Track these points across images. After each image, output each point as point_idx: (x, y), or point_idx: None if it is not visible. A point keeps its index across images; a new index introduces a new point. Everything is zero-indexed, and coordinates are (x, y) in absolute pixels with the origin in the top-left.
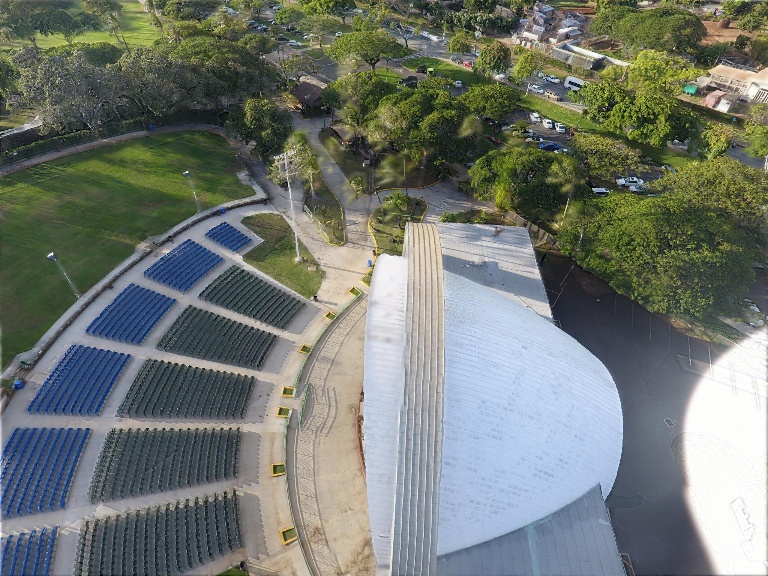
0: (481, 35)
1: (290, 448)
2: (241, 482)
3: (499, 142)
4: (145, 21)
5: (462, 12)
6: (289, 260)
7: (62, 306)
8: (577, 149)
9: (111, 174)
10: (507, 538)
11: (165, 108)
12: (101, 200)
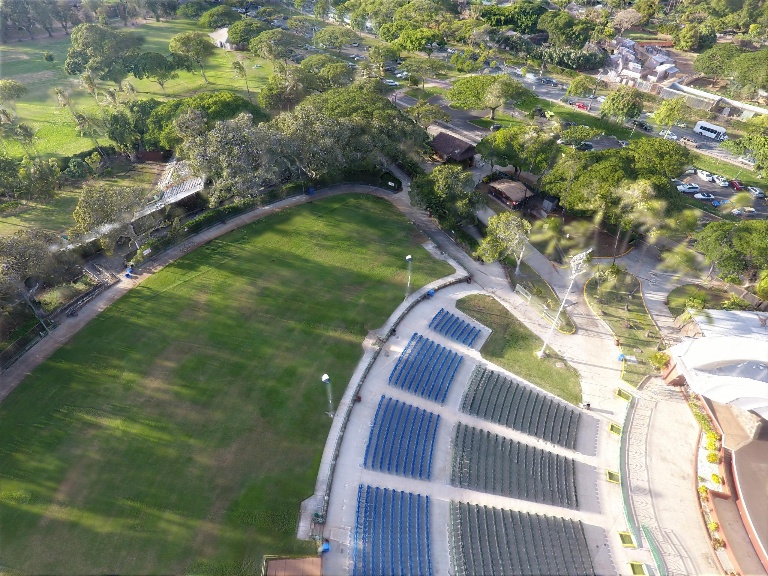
0: (579, 73)
1: None
2: None
3: None
4: (221, 57)
5: (553, 48)
6: (530, 355)
7: (320, 430)
8: None
9: (293, 251)
10: None
11: (326, 170)
12: (298, 285)
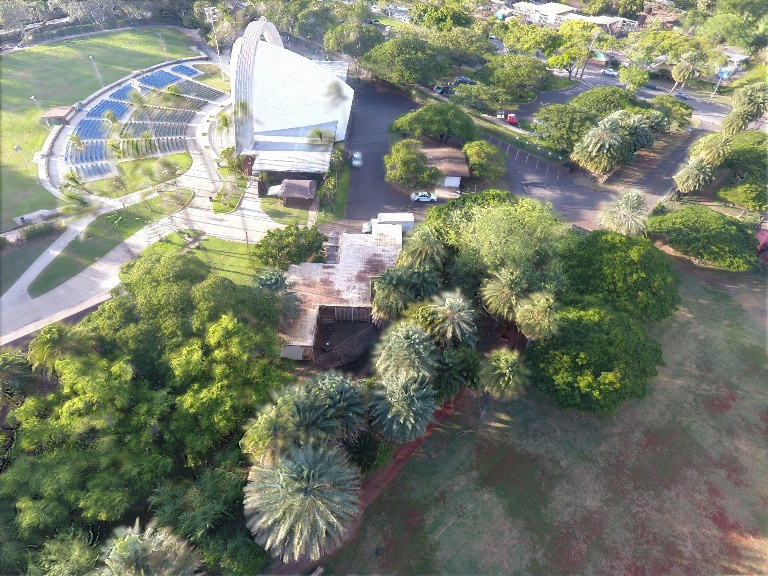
0: None
1: (211, 130)
2: (187, 137)
3: None
4: None
5: None
6: (218, 80)
7: (95, 89)
8: None
9: (113, 44)
10: (292, 129)
11: (145, 13)
12: (109, 54)
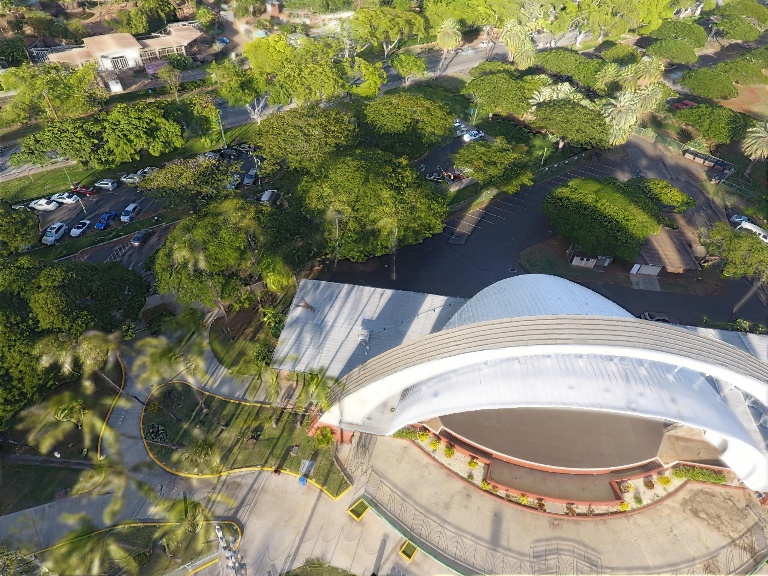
0: None
1: None
2: None
3: None
4: None
5: None
6: None
7: None
8: (175, 194)
9: None
10: None
11: None
12: None
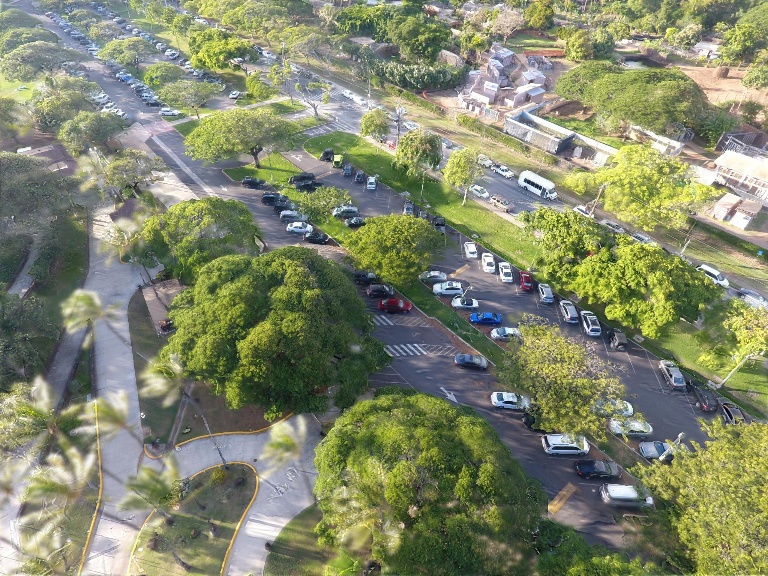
0: (417, 96)
1: None
2: None
3: (410, 308)
4: None
5: (395, 63)
6: None
7: None
8: (520, 369)
9: None
10: None
11: None
12: None
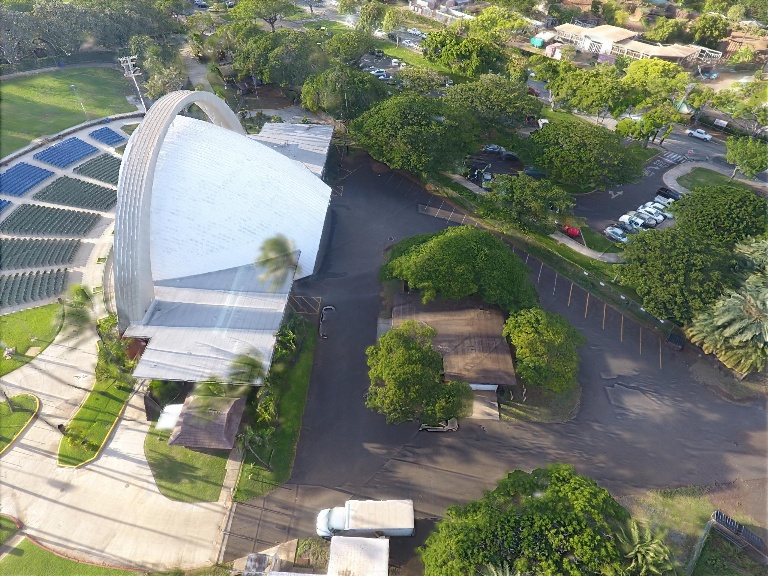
0: (380, 3)
1: None
2: (73, 266)
3: None
4: None
5: None
6: None
7: None
8: None
9: (21, 95)
10: (223, 272)
11: (73, 48)
12: (9, 112)
